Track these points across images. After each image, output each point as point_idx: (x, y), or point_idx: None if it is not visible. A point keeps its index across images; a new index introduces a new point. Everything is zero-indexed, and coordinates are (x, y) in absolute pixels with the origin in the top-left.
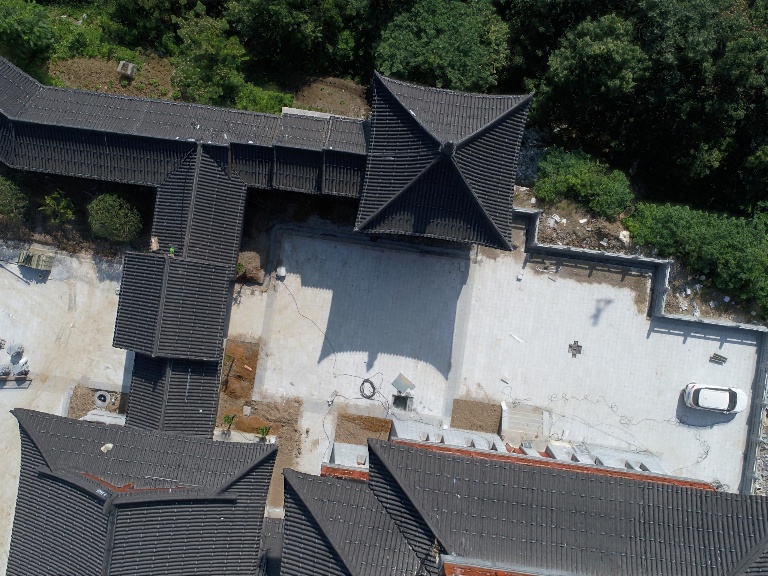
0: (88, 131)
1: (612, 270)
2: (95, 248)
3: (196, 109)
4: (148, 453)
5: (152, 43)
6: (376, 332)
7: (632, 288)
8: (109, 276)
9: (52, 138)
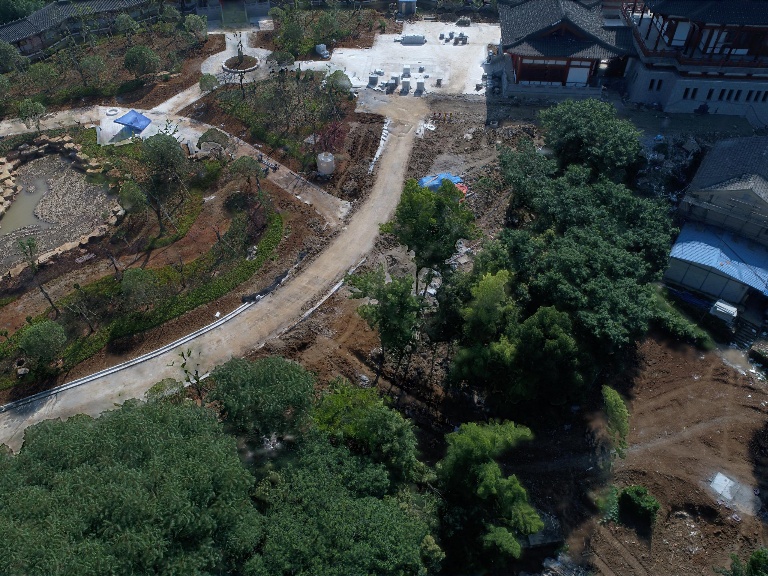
0: None
1: None
2: (486, 22)
3: None
4: None
5: None
6: None
7: None
8: (494, 25)
9: None
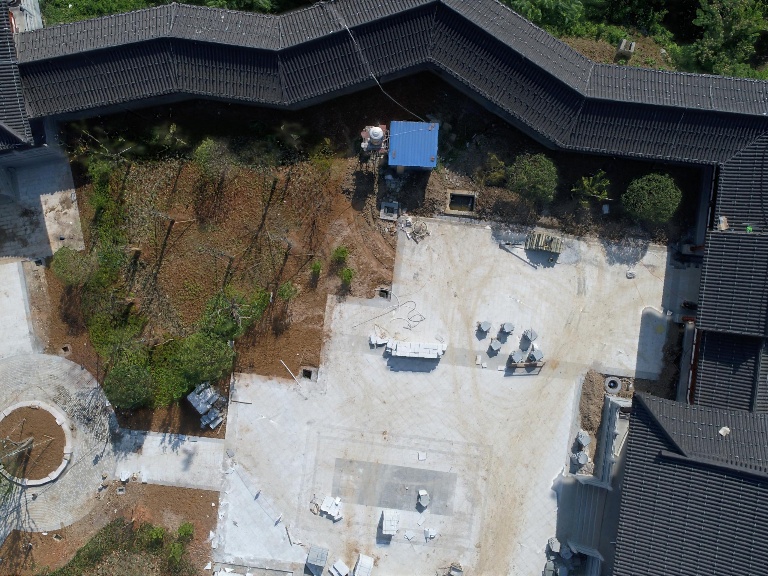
0: (665, 108)
1: None
2: (602, 231)
3: (760, 85)
4: (766, 436)
5: (635, 21)
6: None
7: None
8: (619, 259)
9: (619, 116)
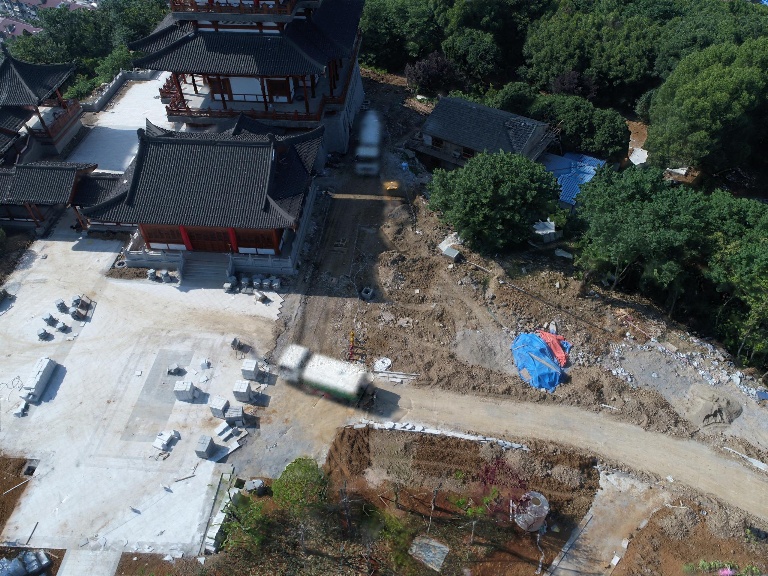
0: None
1: (121, 89)
2: (5, 273)
3: None
4: None
5: None
6: (122, 154)
7: (133, 84)
8: (30, 263)
9: None
